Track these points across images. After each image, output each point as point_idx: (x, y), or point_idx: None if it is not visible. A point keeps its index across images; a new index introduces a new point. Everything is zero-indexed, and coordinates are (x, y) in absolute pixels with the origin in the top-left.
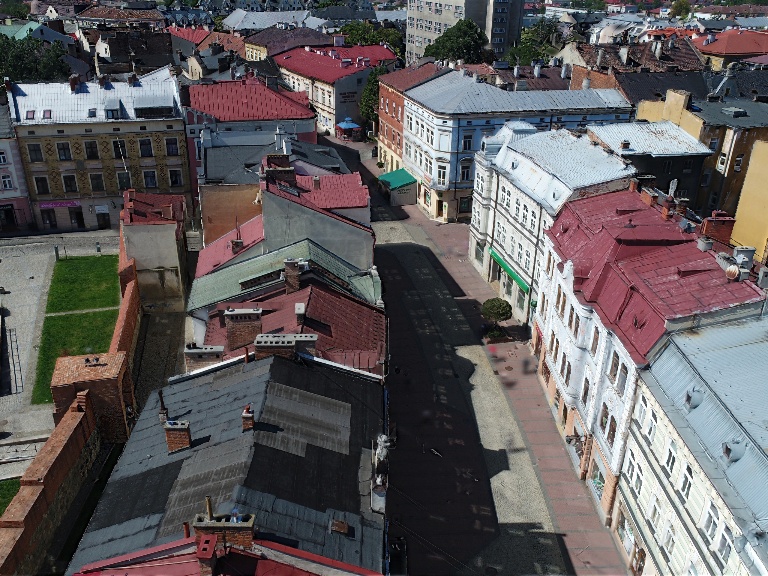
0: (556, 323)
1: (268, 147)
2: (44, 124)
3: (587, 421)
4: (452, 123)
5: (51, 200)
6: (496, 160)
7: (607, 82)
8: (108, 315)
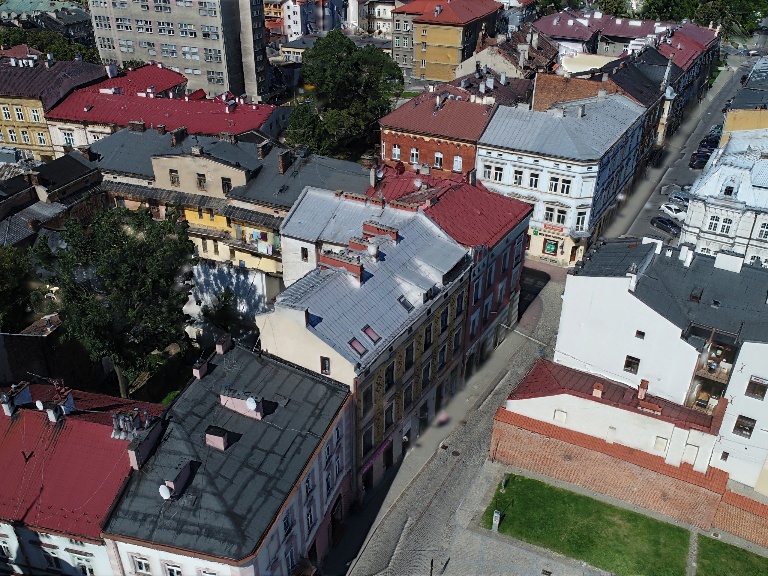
0: None
1: (658, 266)
2: (384, 351)
3: None
4: (598, 168)
5: (372, 455)
6: (742, 200)
7: (603, 88)
8: (717, 549)
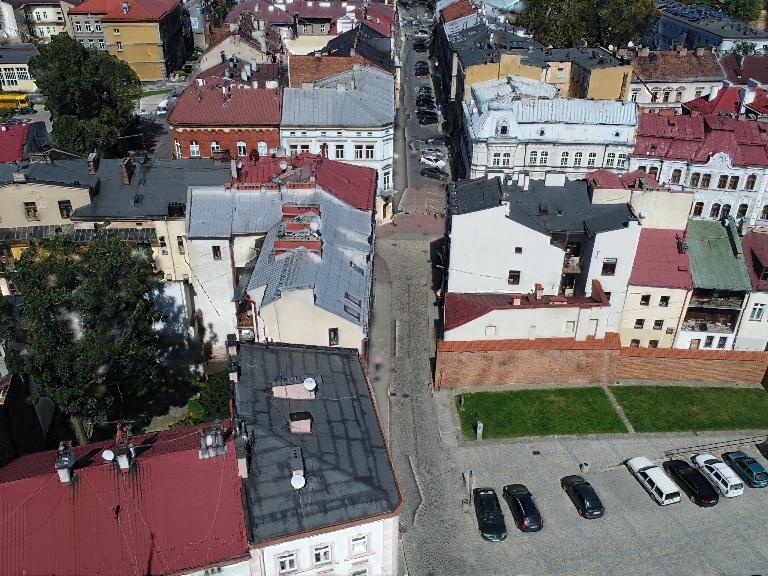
0: (697, 194)
1: None
2: None
3: (751, 223)
4: None
5: None
6: None
7: (352, 63)
8: (625, 392)
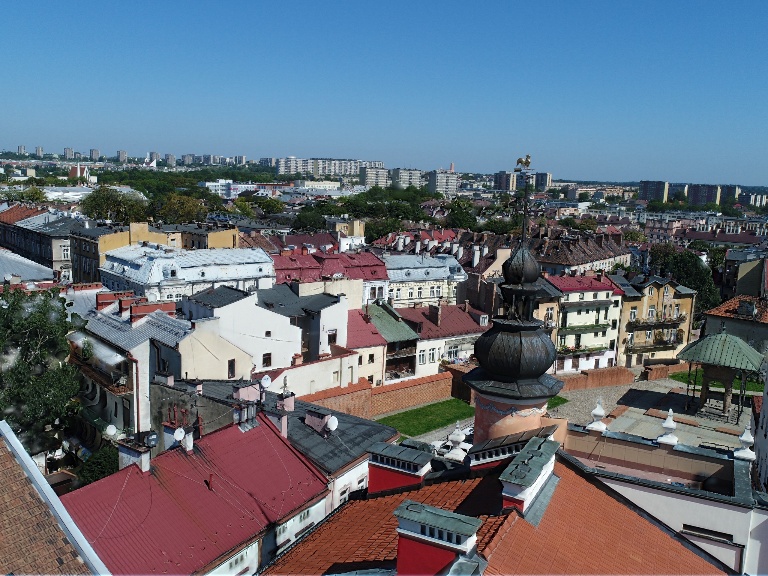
0: None
1: None
2: None
3: None
4: None
5: None
6: None
7: None
8: (384, 421)
